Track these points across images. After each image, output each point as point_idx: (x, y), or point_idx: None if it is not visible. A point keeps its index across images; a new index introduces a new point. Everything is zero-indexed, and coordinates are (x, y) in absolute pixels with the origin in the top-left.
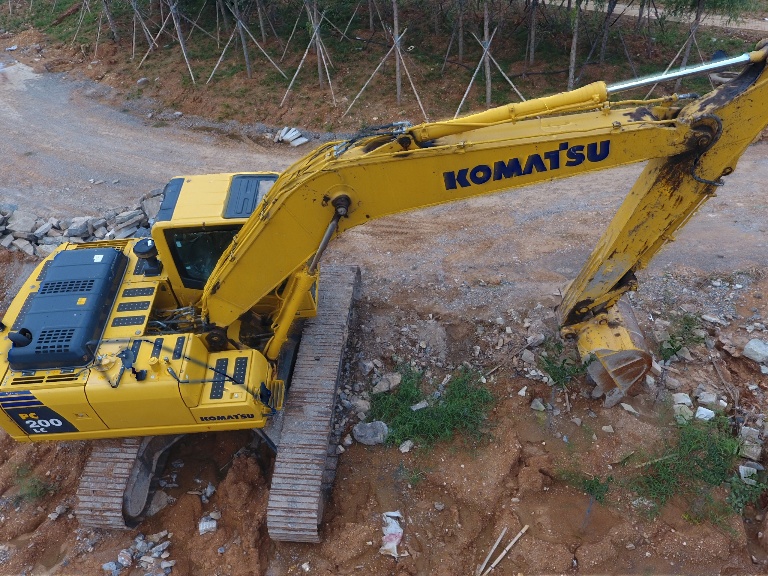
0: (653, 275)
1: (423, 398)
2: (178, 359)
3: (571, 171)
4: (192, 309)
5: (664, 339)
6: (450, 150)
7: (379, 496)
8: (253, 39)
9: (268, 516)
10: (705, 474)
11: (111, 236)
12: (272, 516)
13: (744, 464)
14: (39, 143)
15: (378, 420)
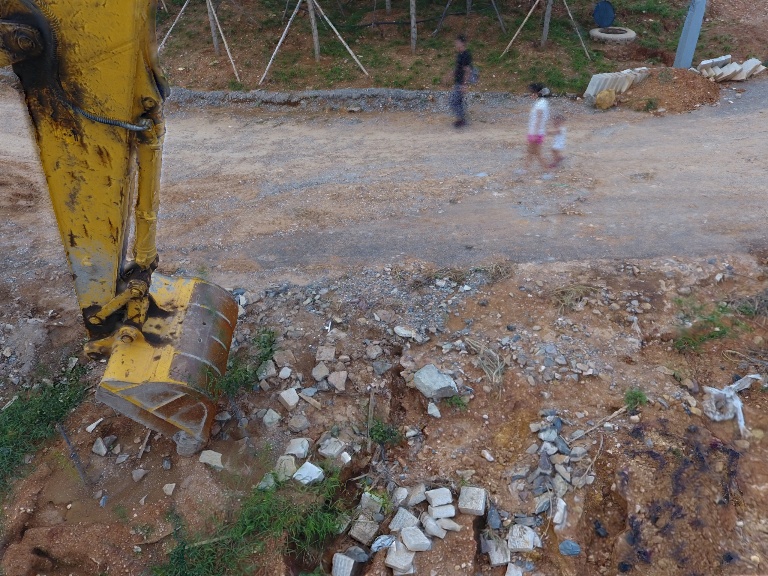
0: (367, 269)
1: None
2: None
3: None
4: None
5: (323, 358)
6: None
7: None
8: None
9: None
10: None
11: None
12: None
13: (345, 550)
14: None
15: None
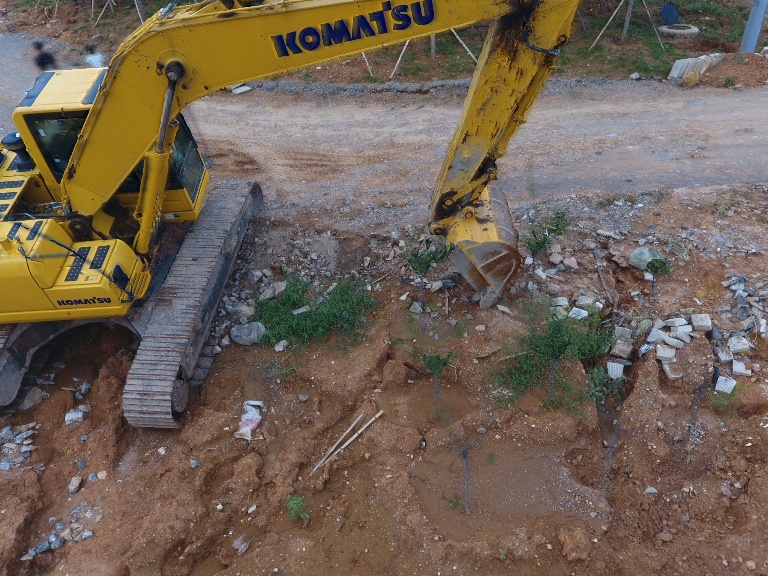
0: (557, 197)
1: (306, 303)
2: (31, 240)
3: (400, 36)
4: None
5: (554, 250)
6: (273, 10)
7: (246, 389)
8: None
9: (123, 399)
10: (531, 339)
11: None
12: (127, 399)
13: (613, 361)
14: None
15: None
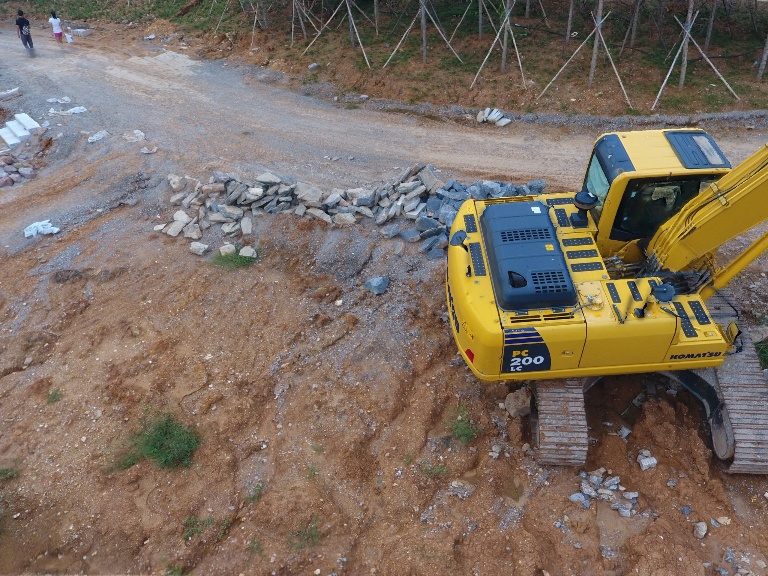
0: None
1: None
2: None
3: None
4: (619, 259)
5: None
6: None
7: None
8: (435, 24)
9: (738, 448)
10: None
11: (401, 205)
12: (742, 448)
13: None
14: (248, 124)
15: (767, 367)
